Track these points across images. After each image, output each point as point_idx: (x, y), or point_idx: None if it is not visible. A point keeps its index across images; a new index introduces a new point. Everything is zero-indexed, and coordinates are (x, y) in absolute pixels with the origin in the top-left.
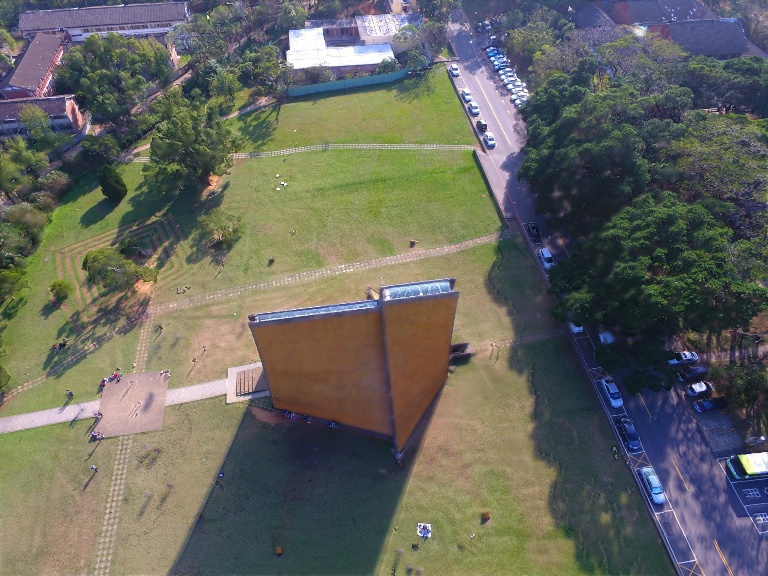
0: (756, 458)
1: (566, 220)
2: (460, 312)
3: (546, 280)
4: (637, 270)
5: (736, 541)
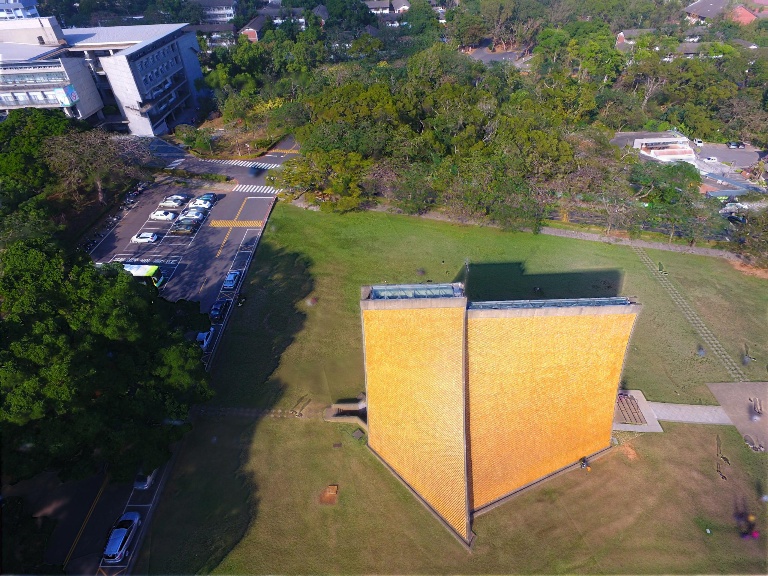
0: (141, 271)
1: (26, 570)
2: (322, 473)
3: (159, 495)
4: (106, 309)
5: (203, 255)
